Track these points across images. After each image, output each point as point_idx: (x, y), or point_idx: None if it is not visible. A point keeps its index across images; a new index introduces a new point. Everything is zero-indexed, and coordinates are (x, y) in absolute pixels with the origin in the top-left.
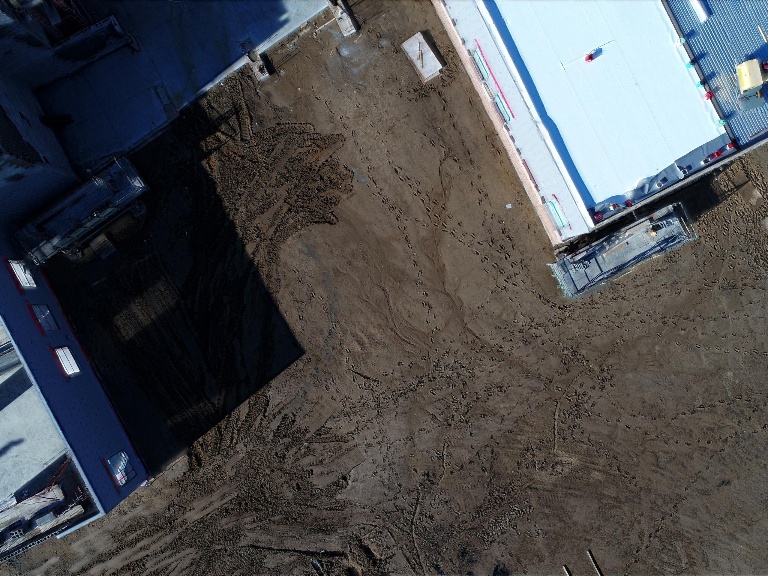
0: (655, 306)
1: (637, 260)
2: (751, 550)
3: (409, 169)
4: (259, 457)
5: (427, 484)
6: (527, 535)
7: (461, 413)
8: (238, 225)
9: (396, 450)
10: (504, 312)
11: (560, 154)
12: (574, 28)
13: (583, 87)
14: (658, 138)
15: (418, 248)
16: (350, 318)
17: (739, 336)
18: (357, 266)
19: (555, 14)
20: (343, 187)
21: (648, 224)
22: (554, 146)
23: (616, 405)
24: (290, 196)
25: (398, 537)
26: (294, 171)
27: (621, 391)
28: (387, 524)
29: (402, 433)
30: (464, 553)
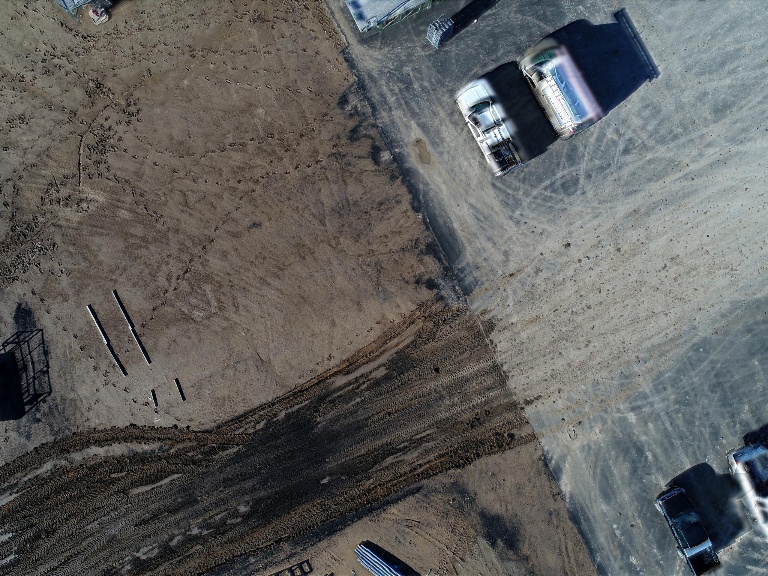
0: (183, 38)
1: None
2: (282, 295)
3: None
4: None
5: None
6: (50, 273)
7: None
8: None
9: None
10: (25, 40)
11: None
12: None
13: None
14: None
15: None
16: None
17: (271, 72)
18: None
19: None
20: None
21: None
22: None
23: (143, 141)
24: None
25: None
26: None
27: (148, 126)
28: None
29: None
30: None
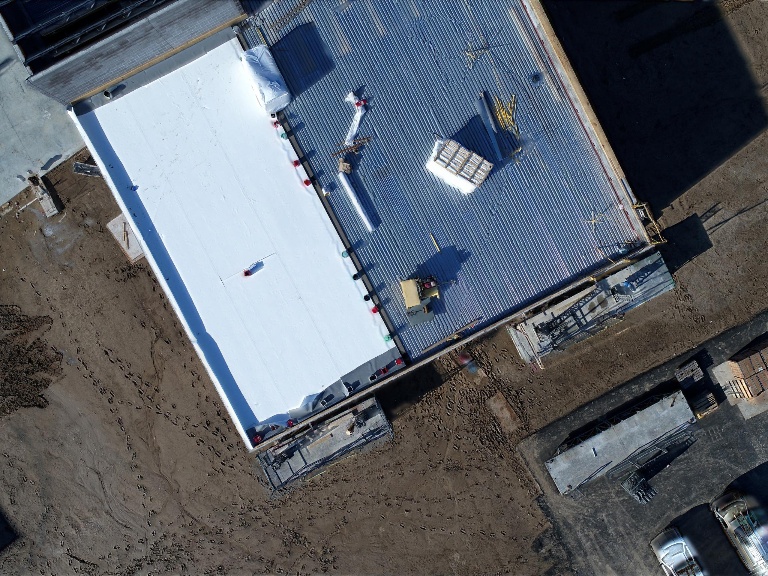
0: (378, 487)
1: (340, 453)
2: None
3: (119, 351)
4: None
5: None
6: None
7: None
8: None
9: None
10: (222, 494)
11: (217, 374)
12: (233, 241)
13: (244, 302)
14: (323, 354)
15: (132, 431)
16: (64, 502)
17: (465, 517)
18: (69, 449)
19: (212, 227)
20: (52, 370)
21: (351, 417)
22: (210, 366)
23: None
24: None
25: None
26: (1, 354)
27: (344, 573)
28: None
29: None
30: None
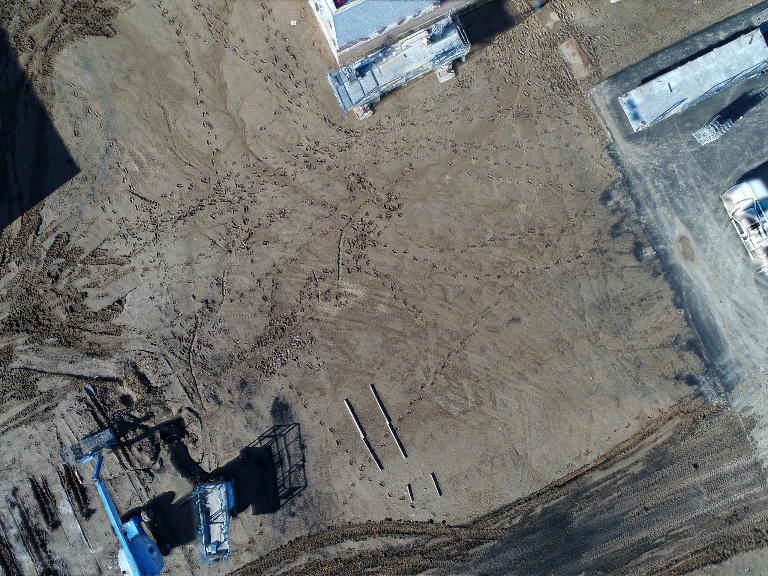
0: (446, 133)
1: (414, 73)
2: (540, 390)
3: None
4: (31, 277)
5: (206, 311)
6: (308, 367)
7: (242, 239)
8: (12, 35)
9: (174, 275)
10: (288, 135)
11: None
12: None
13: None
14: None
15: (199, 65)
16: (128, 136)
17: (533, 167)
18: (136, 82)
19: None
20: None
21: (426, 35)
22: None
23: (403, 235)
24: (66, 7)
25: (175, 365)
26: None
27: (409, 221)
28: (164, 351)
29: (180, 258)
30: (243, 384)
